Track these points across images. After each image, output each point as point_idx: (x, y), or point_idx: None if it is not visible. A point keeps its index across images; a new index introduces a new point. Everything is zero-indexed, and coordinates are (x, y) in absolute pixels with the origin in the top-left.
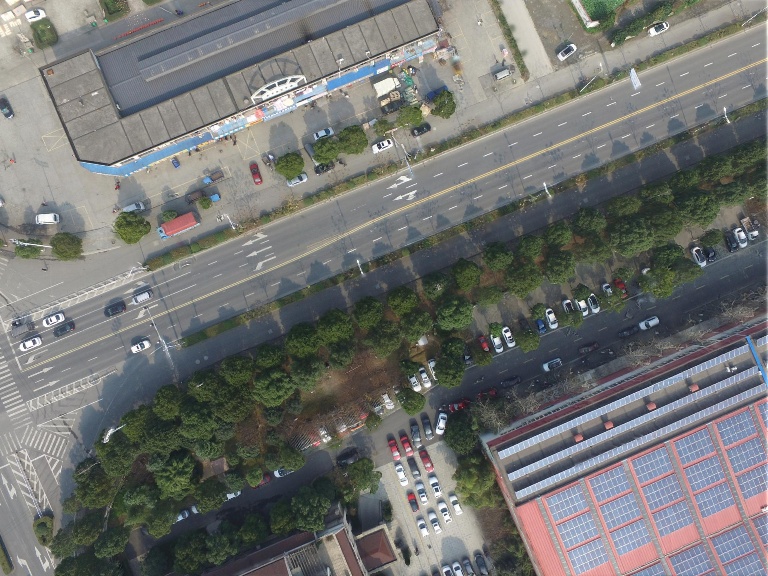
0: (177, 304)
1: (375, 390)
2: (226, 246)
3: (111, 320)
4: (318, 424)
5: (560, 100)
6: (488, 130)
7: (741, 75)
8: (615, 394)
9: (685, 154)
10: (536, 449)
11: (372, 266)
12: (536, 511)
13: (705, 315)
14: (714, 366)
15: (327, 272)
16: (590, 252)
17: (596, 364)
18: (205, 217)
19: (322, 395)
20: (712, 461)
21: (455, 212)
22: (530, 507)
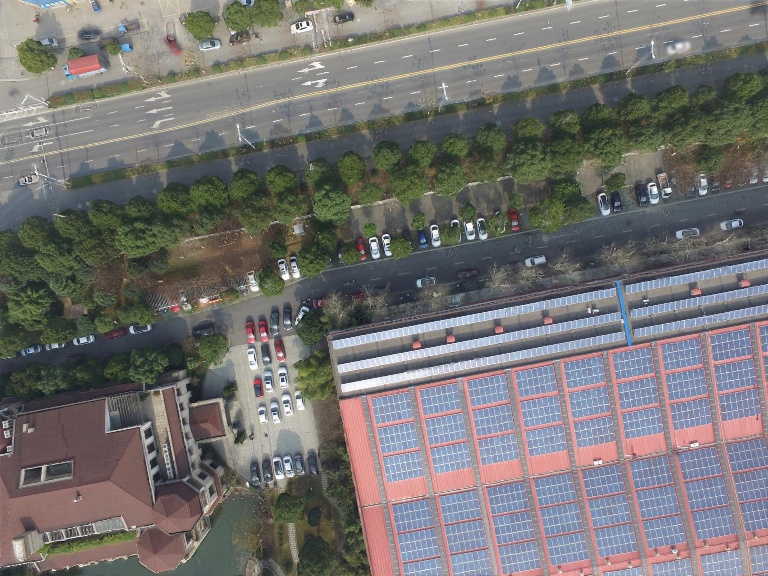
0: (71, 146)
1: (241, 267)
2: (129, 98)
3: (6, 148)
4: (178, 288)
5: (493, 13)
6: (411, 30)
7: (694, 23)
8: (465, 310)
9: (614, 95)
10: (373, 348)
11: (266, 146)
12: (359, 409)
13: (595, 264)
14: (575, 304)
15: (221, 144)
16: (479, 167)
17: (470, 290)
18: (114, 66)
19: (191, 263)
20: (552, 400)
21: (361, 109)
22: (354, 403)
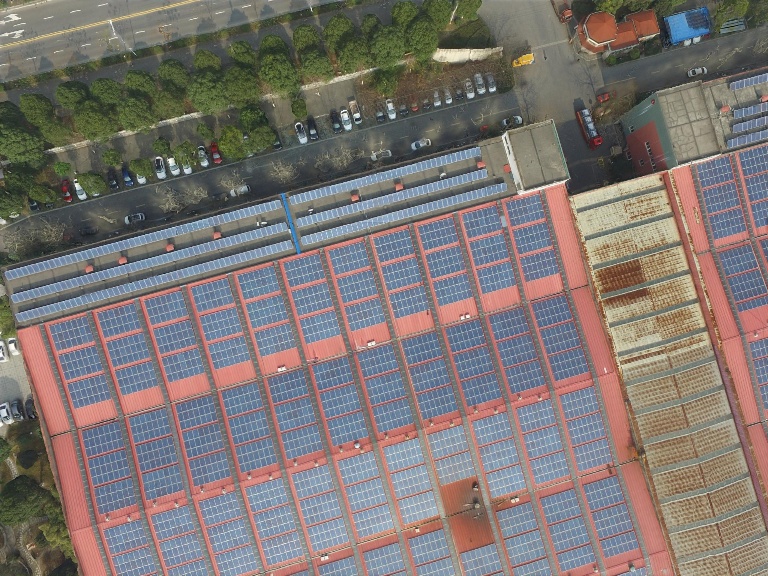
0: None
1: None
2: None
3: None
4: None
5: None
6: None
7: None
8: (137, 232)
9: None
10: (49, 276)
11: None
12: (38, 337)
13: None
14: (245, 219)
15: None
16: (157, 99)
17: None
18: None
19: None
20: (230, 312)
21: (60, 56)
22: (32, 332)
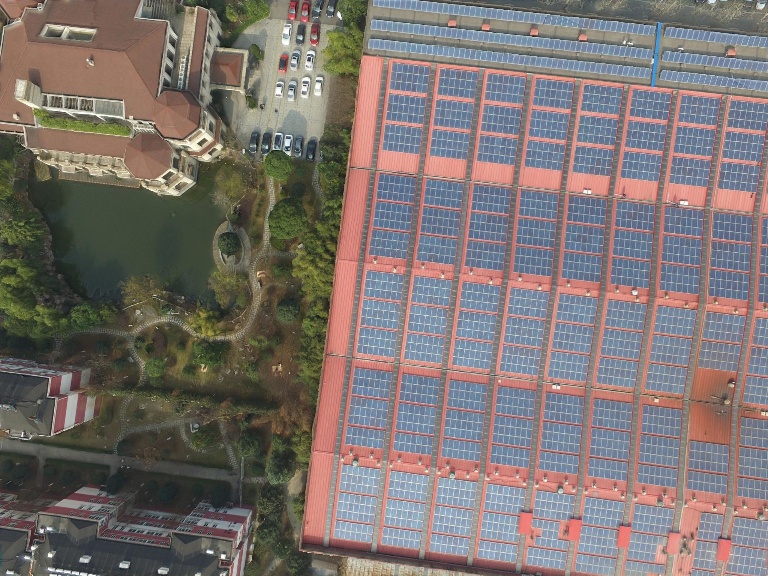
0: None
1: None
2: None
3: None
4: None
5: None
6: None
7: None
8: (507, 6)
9: None
10: (409, 17)
11: None
12: (378, 70)
13: None
14: (613, 33)
15: None
16: None
17: None
18: None
19: None
20: (562, 117)
21: None
22: (375, 63)
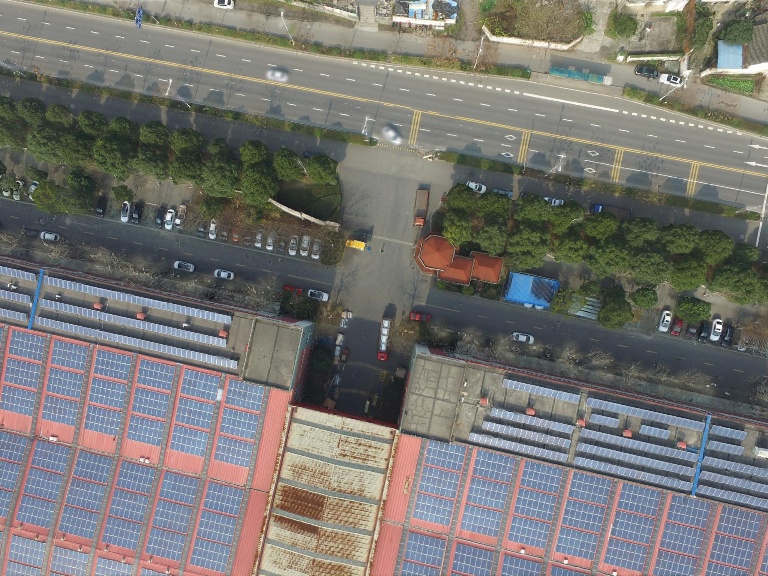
0: None
1: None
2: None
3: None
4: None
5: (101, 9)
6: None
7: (268, 87)
8: None
9: (177, 122)
10: None
11: None
12: None
13: None
14: (2, 275)
15: None
16: None
17: None
18: None
19: None
20: None
21: None
22: None
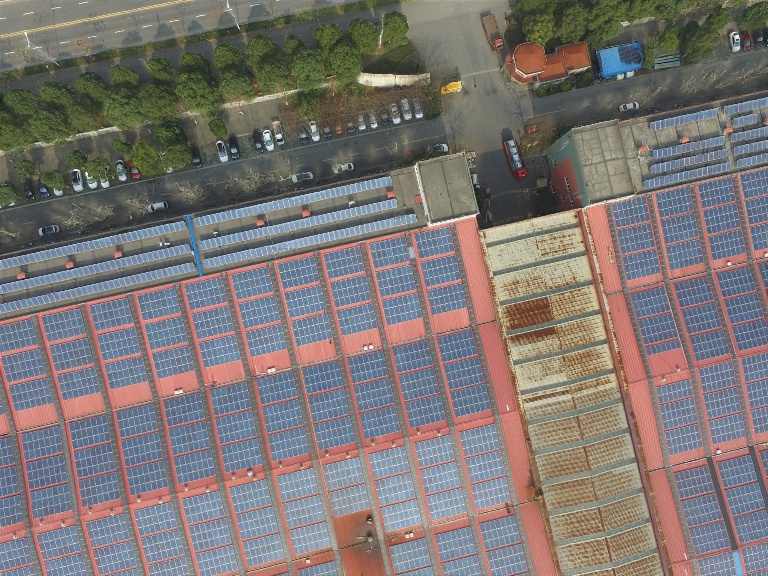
0: None
1: None
2: None
3: None
4: None
5: None
6: None
7: None
8: (38, 247)
9: None
10: None
11: None
12: None
13: None
14: (149, 238)
15: None
16: (70, 112)
17: None
18: None
19: None
20: (128, 333)
21: None
22: None
